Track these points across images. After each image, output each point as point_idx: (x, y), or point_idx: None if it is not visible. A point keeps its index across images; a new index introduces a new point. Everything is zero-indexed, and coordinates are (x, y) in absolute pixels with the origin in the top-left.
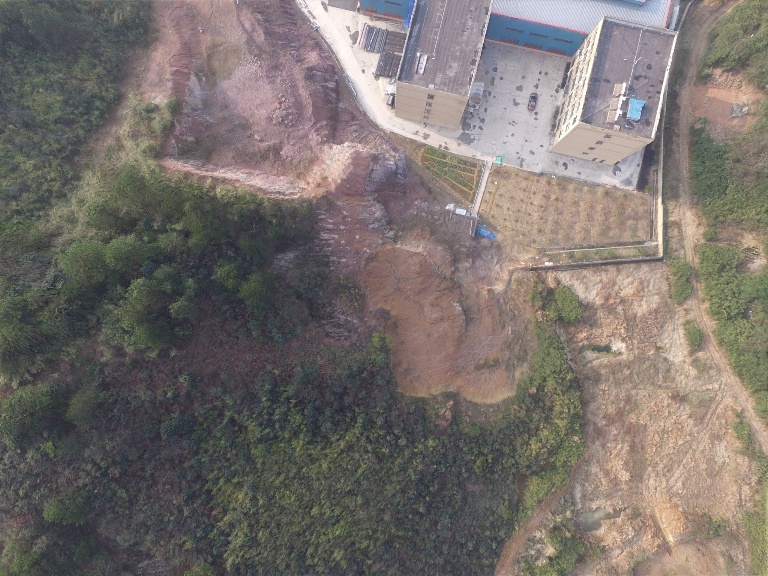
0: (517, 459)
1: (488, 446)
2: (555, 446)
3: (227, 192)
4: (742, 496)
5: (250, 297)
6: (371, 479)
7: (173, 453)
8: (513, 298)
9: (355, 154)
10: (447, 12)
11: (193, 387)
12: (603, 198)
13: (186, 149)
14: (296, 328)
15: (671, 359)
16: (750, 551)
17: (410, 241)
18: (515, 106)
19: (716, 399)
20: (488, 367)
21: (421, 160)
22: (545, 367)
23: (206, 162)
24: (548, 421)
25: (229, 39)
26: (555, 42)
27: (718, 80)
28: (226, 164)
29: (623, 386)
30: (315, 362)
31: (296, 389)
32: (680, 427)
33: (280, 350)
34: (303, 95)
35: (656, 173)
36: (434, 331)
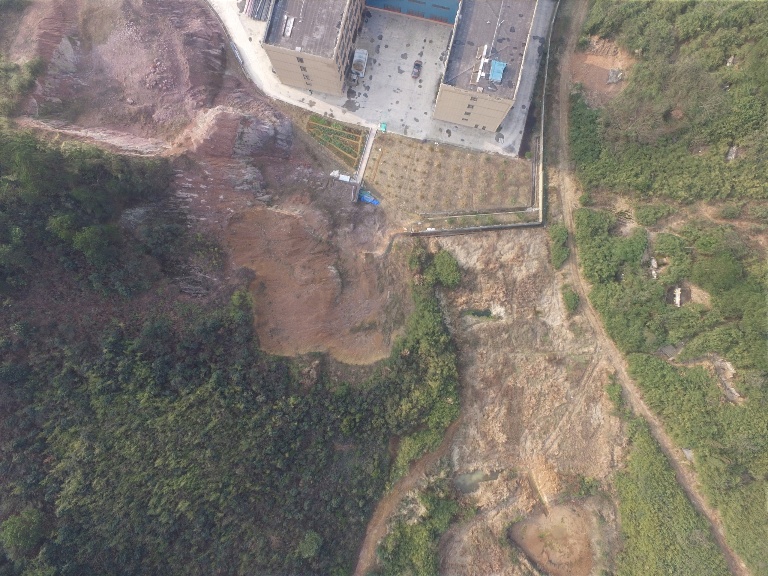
0: (387, 419)
1: (356, 406)
2: (427, 407)
3: (71, 147)
4: (614, 457)
5: (89, 249)
6: (224, 433)
7: (4, 401)
8: (393, 263)
9: (221, 116)
10: None
11: (27, 336)
12: (485, 165)
13: (50, 109)
14: (143, 282)
15: (550, 323)
16: (620, 511)
17: (287, 205)
18: (400, 74)
19: (592, 362)
20: (364, 330)
21: (307, 127)
22: (419, 329)
23: (71, 123)
24: (422, 383)
25: (105, 4)
26: (434, 9)
27: (595, 47)
28: (92, 125)
29: (501, 350)
30: (168, 318)
31: (141, 342)
32: (556, 390)
33: (129, 304)
34: (181, 60)
35: (538, 140)
36: (304, 292)
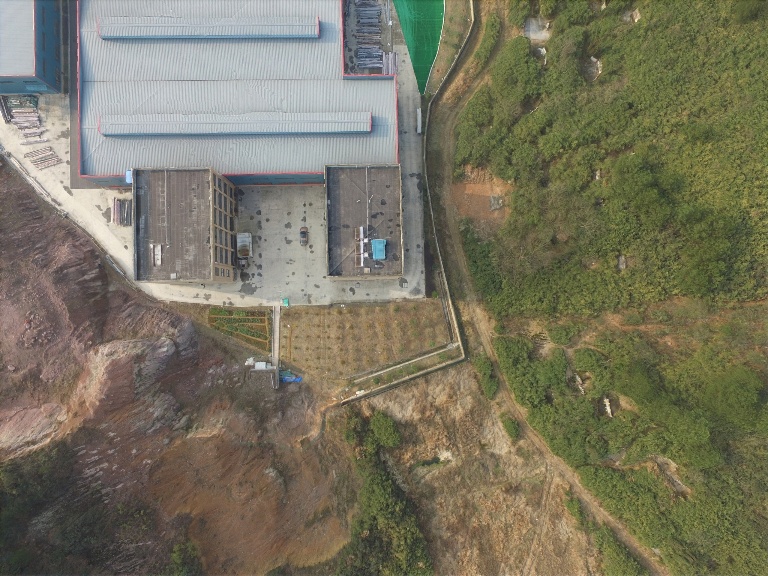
0: None
1: None
2: None
3: None
4: (590, 568)
5: None
6: None
7: None
8: (330, 440)
9: (111, 366)
10: (169, 196)
11: None
12: (396, 314)
13: None
14: None
15: (498, 453)
16: None
17: (208, 418)
18: (288, 244)
19: (547, 481)
20: (318, 520)
21: (208, 322)
22: (372, 506)
23: None
24: (389, 557)
25: None
26: (304, 179)
27: (471, 176)
28: None
29: (458, 493)
30: None
31: None
32: (520, 518)
33: None
34: (56, 302)
35: (441, 275)
36: (247, 511)
